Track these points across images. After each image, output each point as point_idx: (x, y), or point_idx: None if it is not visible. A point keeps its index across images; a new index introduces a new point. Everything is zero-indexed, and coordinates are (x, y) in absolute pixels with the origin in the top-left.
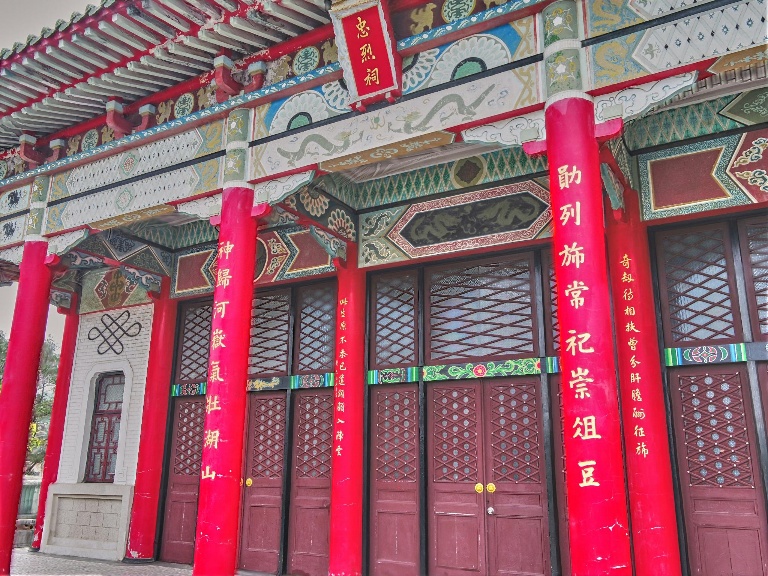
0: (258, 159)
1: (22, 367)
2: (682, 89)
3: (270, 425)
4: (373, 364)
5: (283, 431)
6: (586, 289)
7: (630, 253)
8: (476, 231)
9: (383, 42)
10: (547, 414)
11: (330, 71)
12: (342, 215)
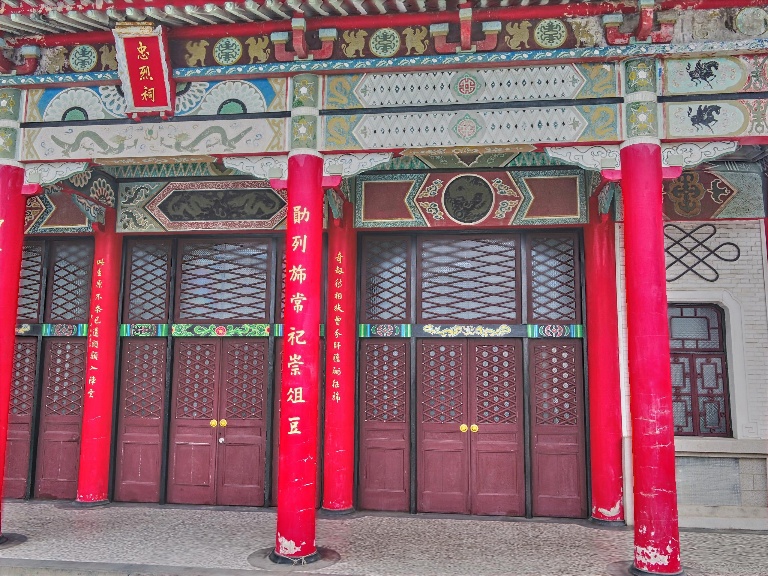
0: (30, 142)
1: None
2: (382, 163)
3: (18, 367)
4: (126, 319)
5: (32, 373)
6: (305, 299)
7: (343, 251)
8: (226, 215)
9: (161, 68)
10: (271, 368)
11: (109, 78)
12: (103, 184)
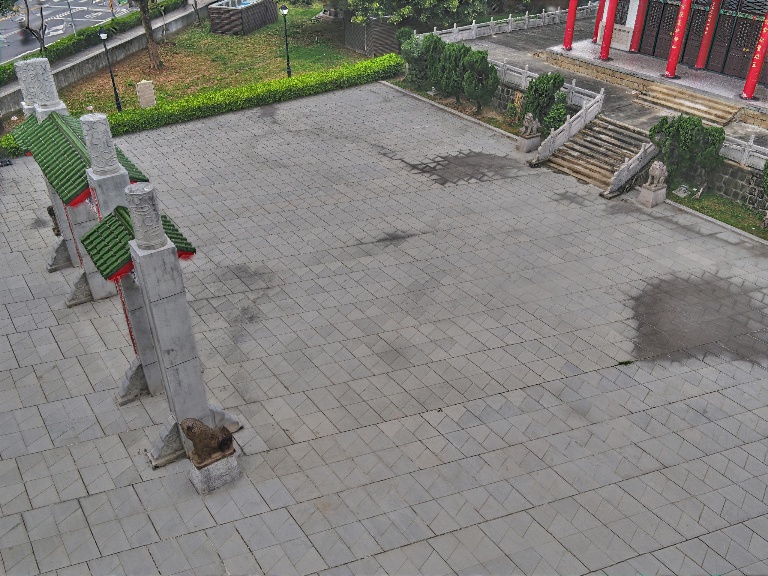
0: None
1: (615, 2)
2: None
3: None
4: (723, 7)
5: (688, 21)
6: (767, 30)
7: None
8: None
9: None
10: None
11: None
12: None
